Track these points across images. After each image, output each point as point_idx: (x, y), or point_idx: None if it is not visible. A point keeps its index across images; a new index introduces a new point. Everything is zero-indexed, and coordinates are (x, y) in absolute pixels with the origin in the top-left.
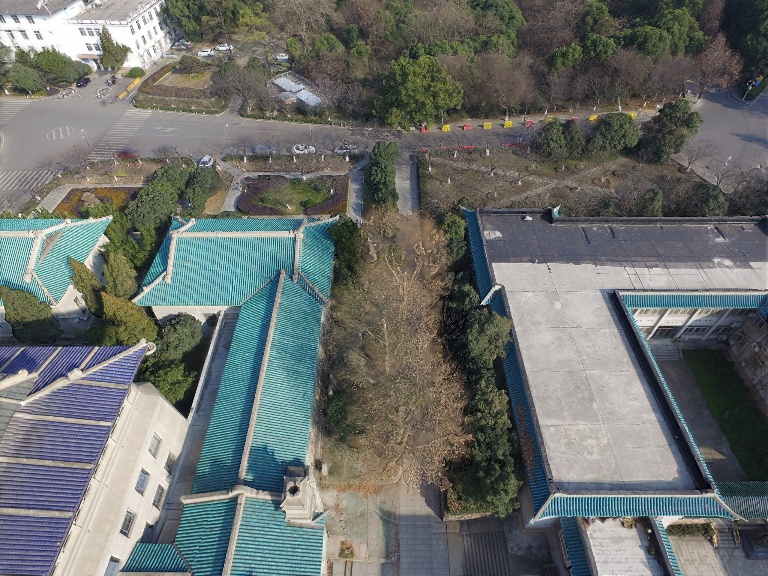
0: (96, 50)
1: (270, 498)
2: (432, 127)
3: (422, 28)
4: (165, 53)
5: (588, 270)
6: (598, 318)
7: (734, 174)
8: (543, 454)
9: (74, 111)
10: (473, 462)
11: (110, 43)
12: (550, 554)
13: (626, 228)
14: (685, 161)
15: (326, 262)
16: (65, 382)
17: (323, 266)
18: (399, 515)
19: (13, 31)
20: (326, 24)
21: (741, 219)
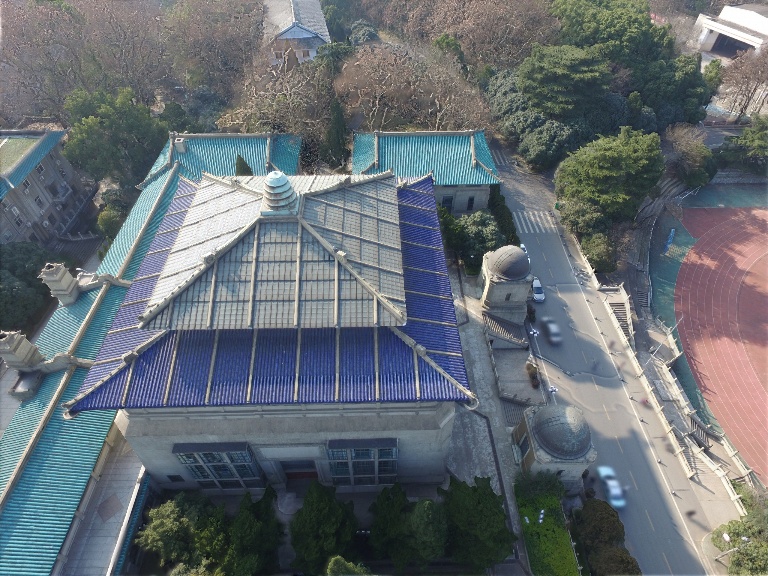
0: None
1: None
2: None
3: None
4: None
5: None
6: None
7: None
8: None
9: None
10: None
11: None
12: None
13: None
14: None
15: None
16: None
17: None
18: (1, 437)
19: None
20: None
21: None
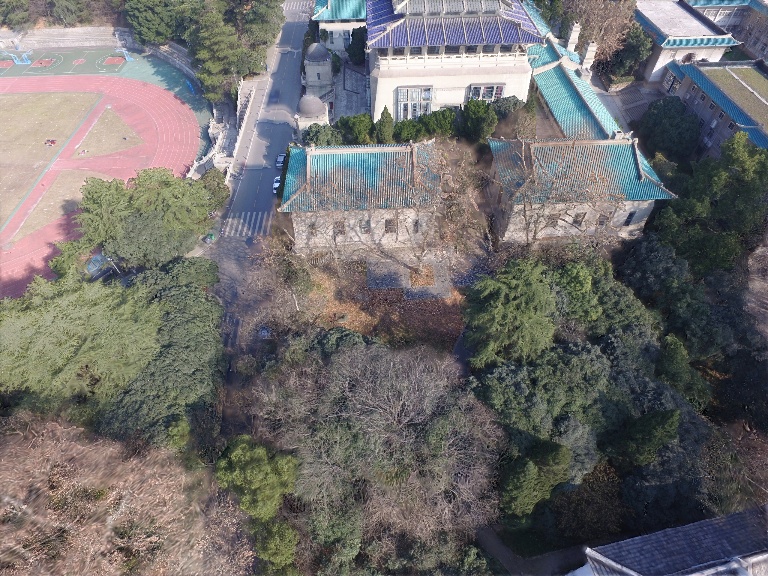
0: None
1: (557, 42)
2: None
3: None
4: None
5: None
6: (673, 8)
7: None
8: (661, 31)
9: None
10: None
11: None
12: None
13: None
14: None
15: (531, 1)
16: None
17: None
18: None
19: None
20: None
21: None
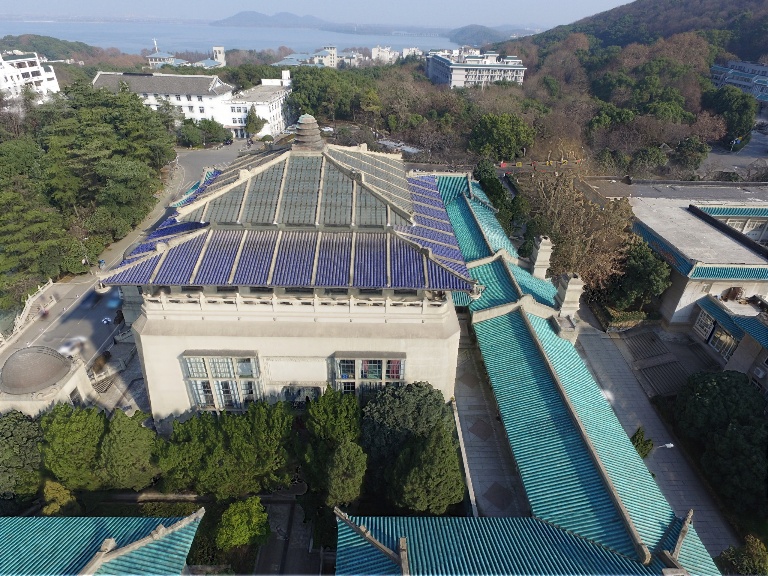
0: (239, 123)
1: (517, 264)
2: (508, 164)
3: (488, 110)
4: (284, 130)
5: (666, 200)
6: (684, 216)
7: (742, 175)
8: (681, 252)
9: (229, 156)
10: (630, 273)
11: (254, 116)
12: (691, 340)
13: (682, 187)
14: (703, 175)
15: (484, 197)
16: (407, 175)
17: (484, 198)
18: None
19: (184, 106)
20: (420, 104)
21: (758, 183)
